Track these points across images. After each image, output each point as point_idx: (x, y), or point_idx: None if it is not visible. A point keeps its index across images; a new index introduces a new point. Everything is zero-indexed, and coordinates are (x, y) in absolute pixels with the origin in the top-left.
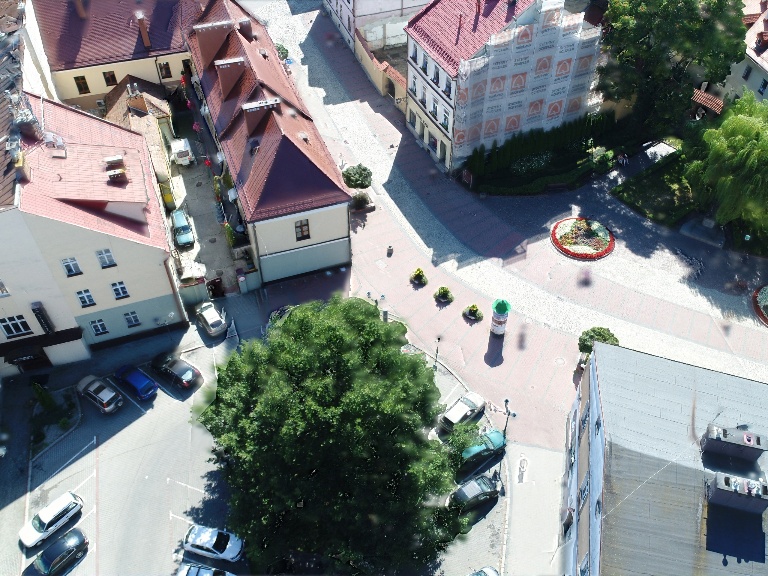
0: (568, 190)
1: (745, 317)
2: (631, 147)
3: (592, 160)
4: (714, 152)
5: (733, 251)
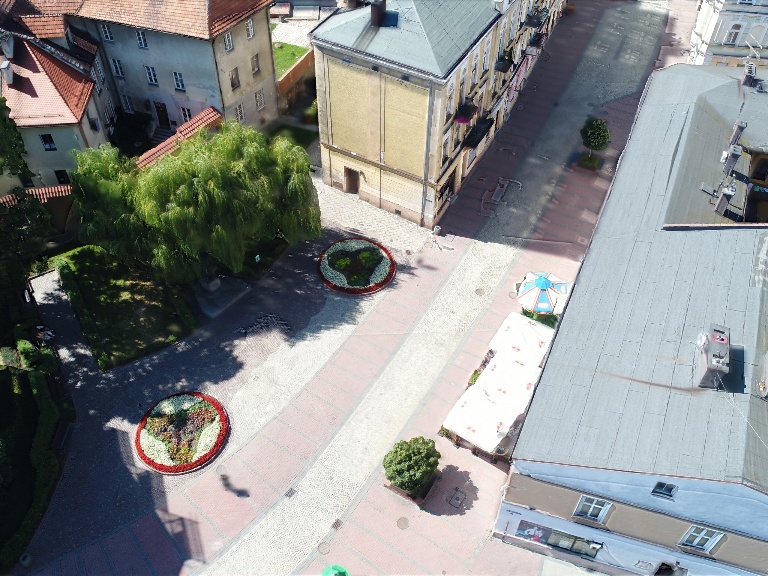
0: (72, 422)
1: (359, 306)
2: (24, 316)
3: (24, 372)
4: (175, 224)
5: (260, 280)
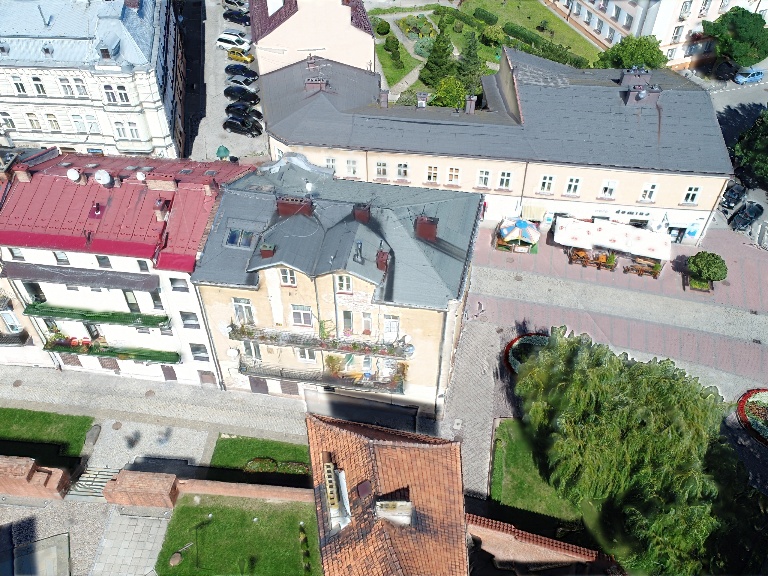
0: None
1: None
2: None
3: None
4: None
5: None
